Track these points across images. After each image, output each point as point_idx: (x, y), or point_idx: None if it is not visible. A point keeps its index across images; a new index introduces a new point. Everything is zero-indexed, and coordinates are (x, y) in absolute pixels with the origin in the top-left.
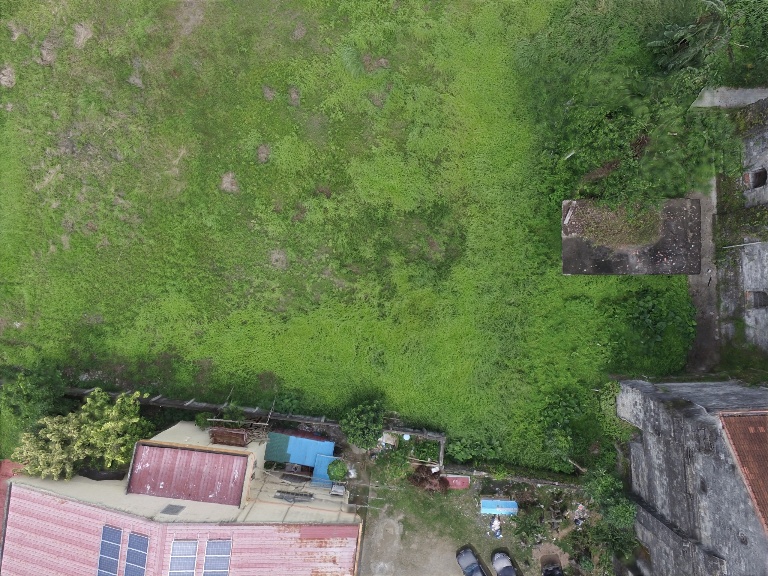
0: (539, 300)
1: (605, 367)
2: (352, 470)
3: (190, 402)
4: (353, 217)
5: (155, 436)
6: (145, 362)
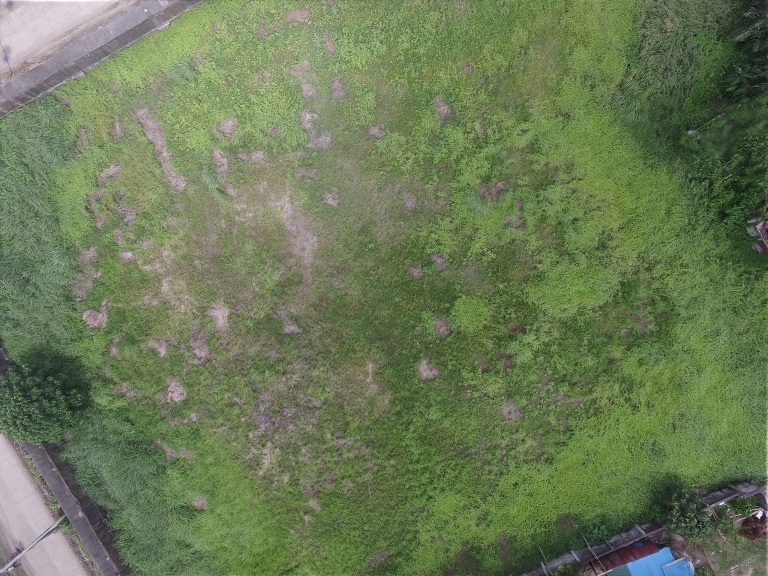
0: (762, 315)
1: None
2: None
3: None
4: (557, 338)
5: None
6: (450, 570)
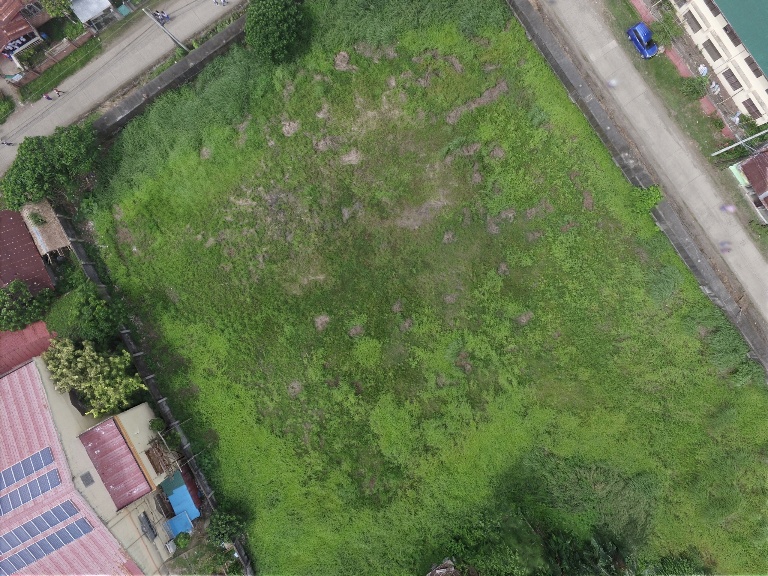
0: (383, 575)
1: None
2: (192, 532)
3: (162, 400)
4: (354, 420)
5: (125, 412)
6: (168, 350)
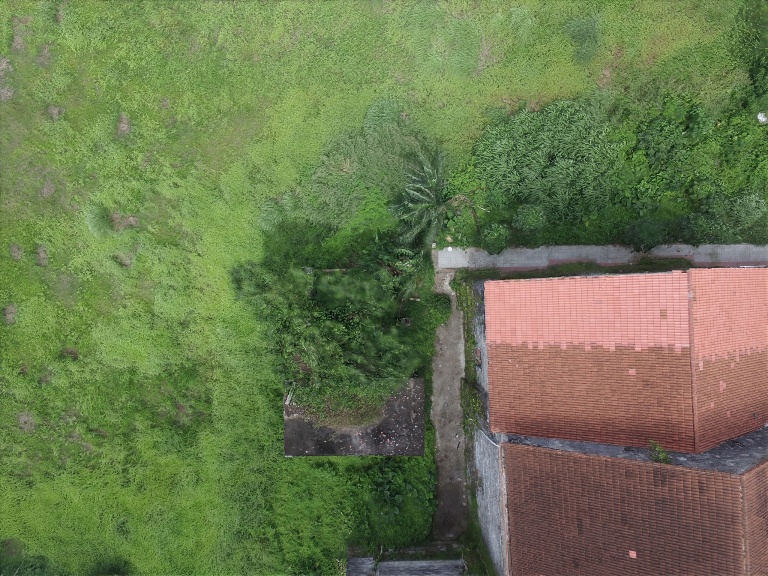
0: (286, 465)
1: (349, 536)
2: None
3: None
4: (98, 381)
5: None
6: None
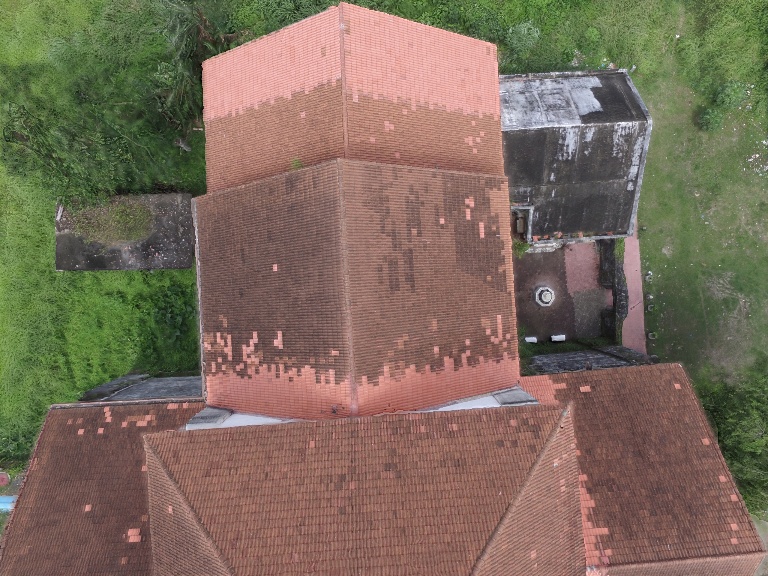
0: (79, 296)
1: (136, 362)
2: None
3: None
4: None
5: None
6: None
